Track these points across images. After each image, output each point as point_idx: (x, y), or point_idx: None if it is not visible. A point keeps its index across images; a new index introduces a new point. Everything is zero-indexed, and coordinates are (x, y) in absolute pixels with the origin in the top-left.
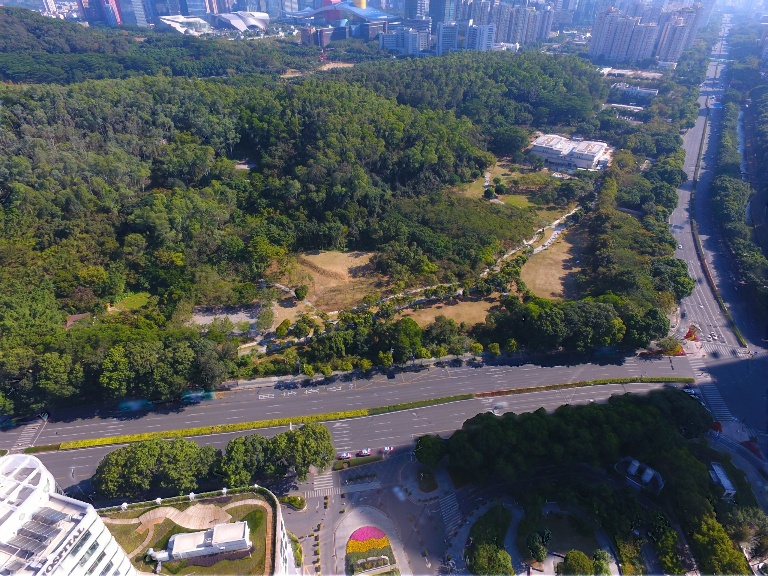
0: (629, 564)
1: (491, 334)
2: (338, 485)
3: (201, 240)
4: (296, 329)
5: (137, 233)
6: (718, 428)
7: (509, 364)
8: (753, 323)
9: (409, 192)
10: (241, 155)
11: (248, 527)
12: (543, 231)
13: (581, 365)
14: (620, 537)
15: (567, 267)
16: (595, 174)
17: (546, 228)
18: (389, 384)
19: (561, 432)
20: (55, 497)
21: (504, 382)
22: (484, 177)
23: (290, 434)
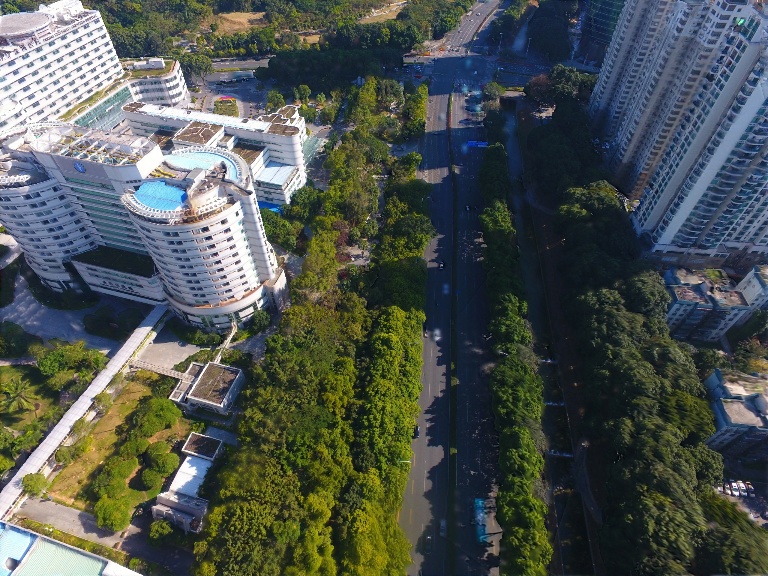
0: None
1: (322, 46)
2: (218, 88)
3: None
4: (206, 36)
5: None
6: (419, 77)
7: None
8: (484, 45)
9: None
10: None
11: None
12: (389, 5)
13: None
14: (333, 91)
15: None
16: None
17: (394, 4)
18: (255, 62)
19: (319, 57)
20: (86, 11)
21: None
22: None
23: (191, 58)
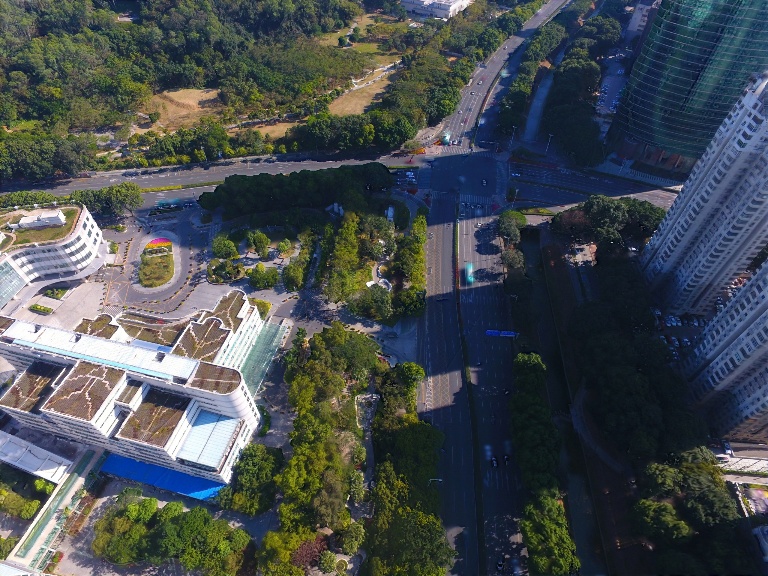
0: (306, 249)
1: (289, 142)
2: (150, 222)
3: (75, 78)
4: (139, 138)
5: (19, 71)
6: (413, 192)
7: (294, 160)
8: (491, 134)
9: (269, 40)
10: (124, 8)
11: (65, 216)
12: (373, 72)
13: (346, 160)
14: (300, 234)
15: (376, 98)
16: (437, 22)
17: (378, 70)
18: (203, 172)
19: (282, 183)
20: None
21: (285, 170)
22: (349, 28)
23: (111, 187)
